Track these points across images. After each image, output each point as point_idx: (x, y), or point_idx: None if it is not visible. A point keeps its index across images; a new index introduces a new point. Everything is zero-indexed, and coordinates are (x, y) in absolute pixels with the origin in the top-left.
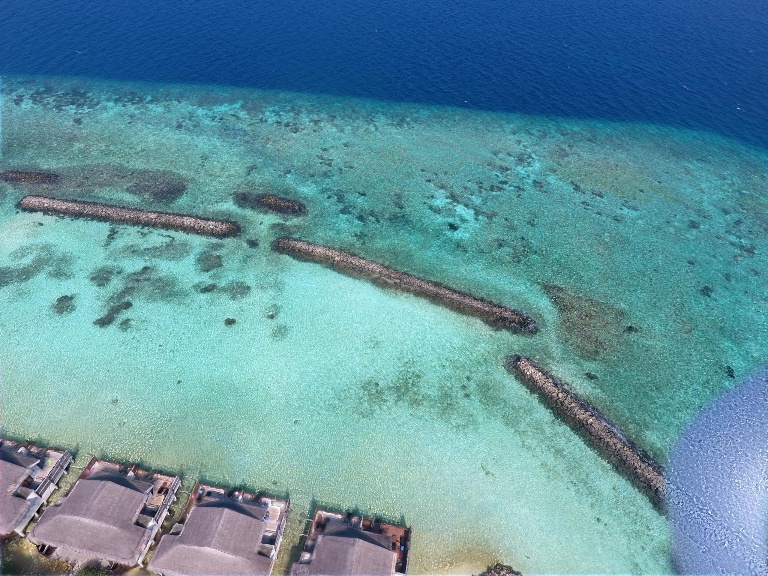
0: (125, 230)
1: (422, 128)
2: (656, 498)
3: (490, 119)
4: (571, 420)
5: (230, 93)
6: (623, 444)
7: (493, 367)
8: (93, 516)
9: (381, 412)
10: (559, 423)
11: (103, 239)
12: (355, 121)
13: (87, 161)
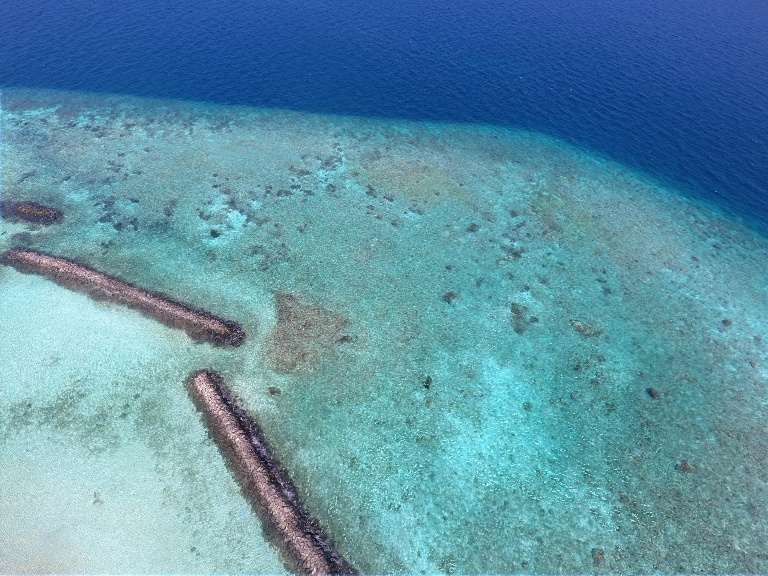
0: None
1: (240, 131)
2: (268, 523)
3: (319, 122)
4: (222, 439)
5: (53, 97)
6: (259, 464)
7: (171, 383)
8: None
9: (16, 436)
10: (209, 443)
11: None
12: (172, 125)
13: None
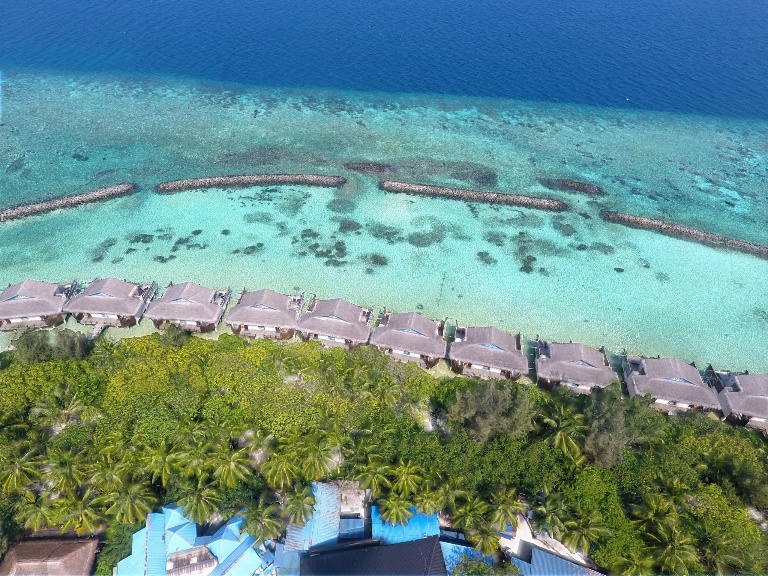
0: (479, 206)
1: (641, 128)
2: None
3: (691, 120)
4: None
5: (459, 100)
6: None
7: None
8: (685, 377)
9: None
10: None
11: (469, 212)
12: (582, 122)
13: (400, 155)
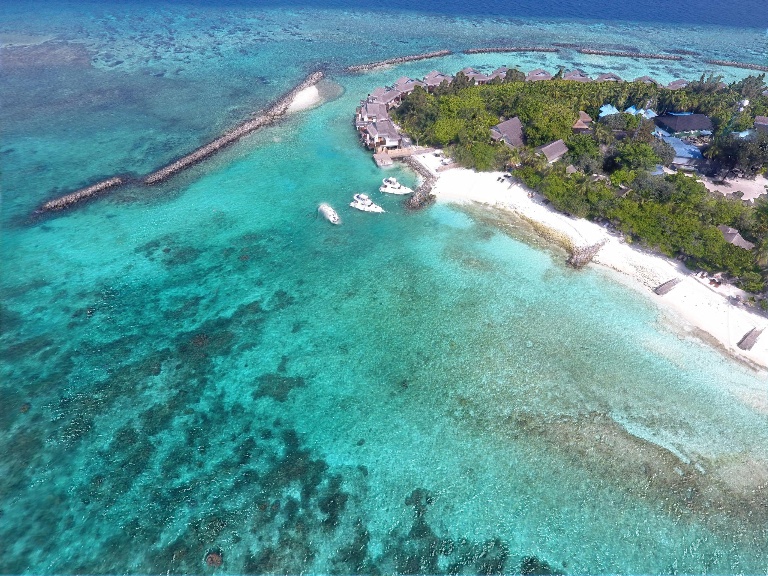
0: None
1: (707, 31)
2: None
3: (736, 28)
4: None
5: (589, 20)
6: None
7: None
8: None
9: None
10: None
11: None
12: (671, 29)
13: (577, 41)
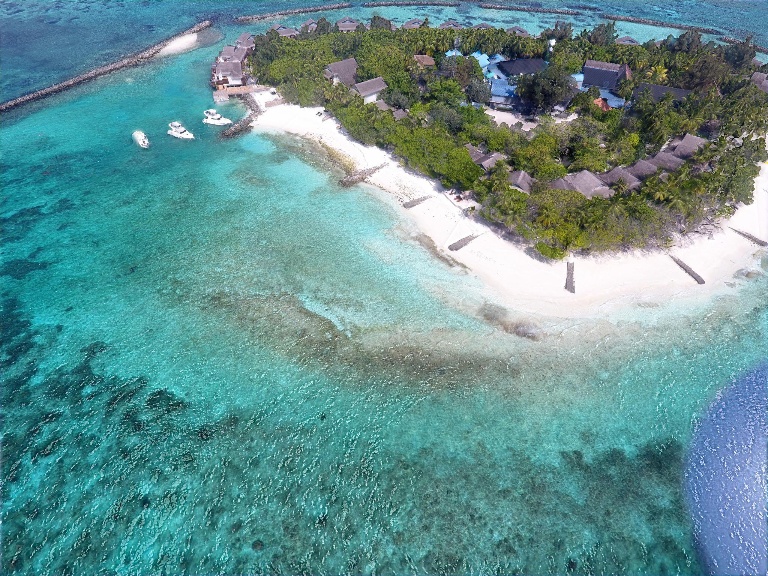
0: (535, 13)
1: None
2: None
3: None
4: None
5: None
6: None
7: None
8: None
9: None
10: None
11: None
12: None
13: None
